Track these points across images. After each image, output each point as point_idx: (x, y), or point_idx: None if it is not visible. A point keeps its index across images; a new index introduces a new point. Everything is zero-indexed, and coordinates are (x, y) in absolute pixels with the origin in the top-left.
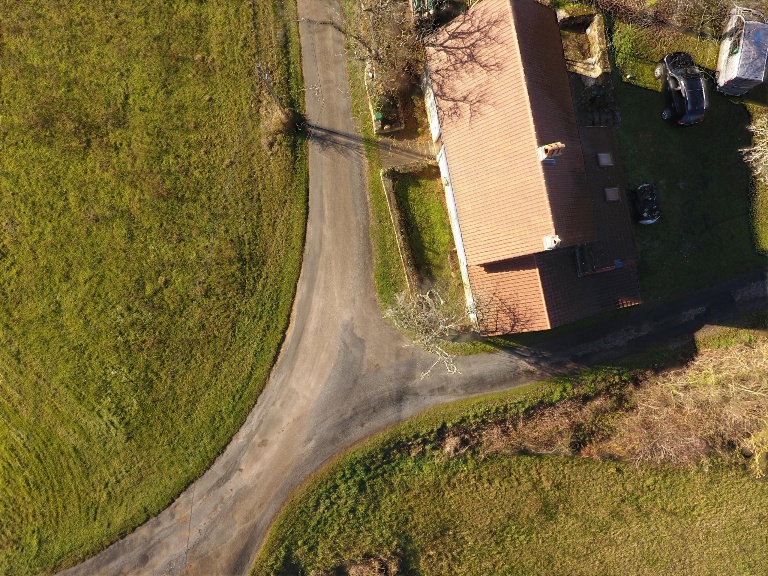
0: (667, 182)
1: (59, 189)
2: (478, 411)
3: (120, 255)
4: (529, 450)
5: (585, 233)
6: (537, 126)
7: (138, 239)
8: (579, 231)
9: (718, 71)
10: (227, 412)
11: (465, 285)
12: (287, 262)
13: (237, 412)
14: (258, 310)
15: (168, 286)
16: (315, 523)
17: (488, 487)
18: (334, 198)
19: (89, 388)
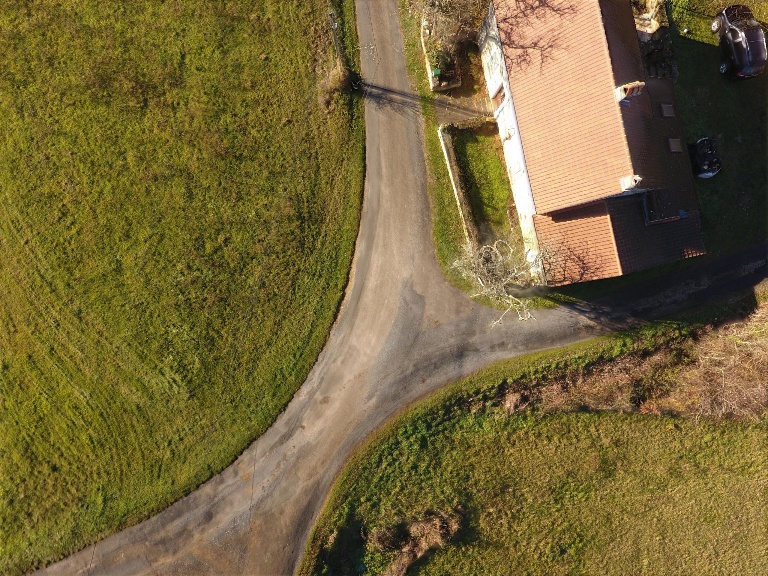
0: (725, 136)
1: (117, 149)
2: (539, 366)
3: (179, 214)
4: (589, 406)
5: (657, 178)
6: (614, 67)
7: (197, 198)
8: (652, 175)
9: None
10: (288, 369)
11: (526, 240)
12: (345, 220)
13: (298, 369)
14: (317, 268)
15: (228, 244)
16: (377, 479)
17: (547, 444)
18: (391, 156)
19: (151, 346)
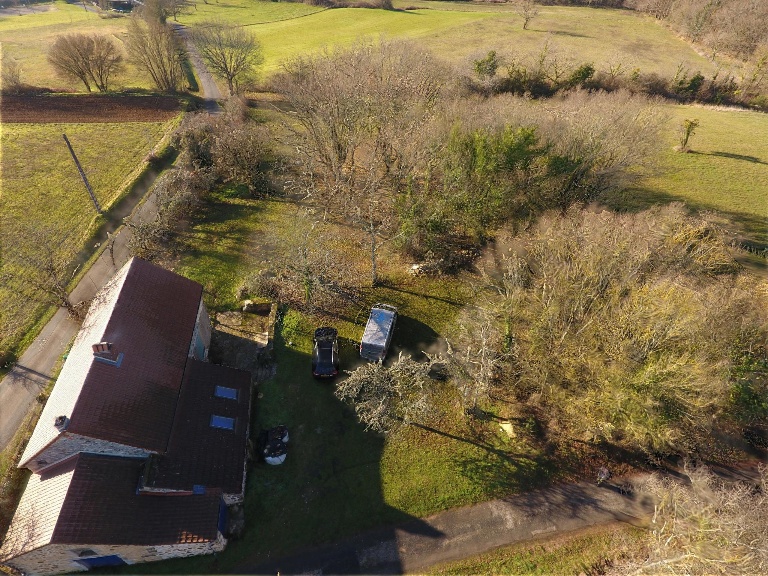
0: (306, 427)
1: None
2: None
3: None
4: None
5: (137, 436)
6: (109, 335)
7: None
8: (125, 430)
9: None
10: None
11: None
12: None
13: None
14: None
15: None
16: None
17: None
18: None
19: None
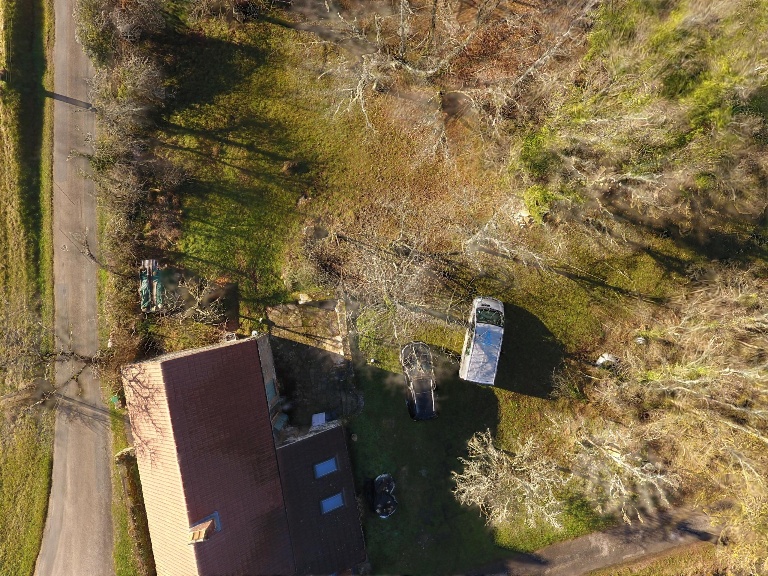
0: (410, 469)
1: None
2: None
3: None
4: None
5: None
6: (192, 502)
7: None
8: None
9: (461, 359)
10: None
11: None
12: (27, 539)
13: None
14: None
15: None
16: None
17: None
18: (77, 473)
19: None
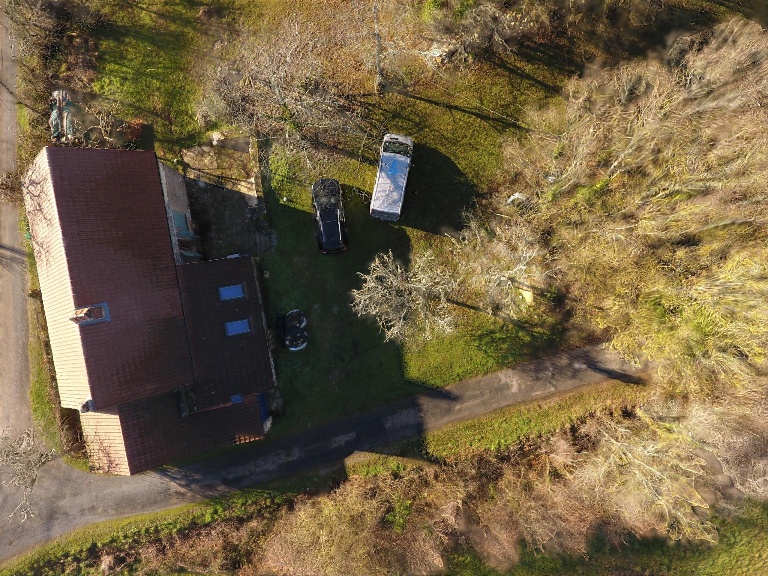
0: (322, 306)
1: None
2: (128, 532)
3: None
4: (186, 569)
5: (163, 382)
6: (78, 287)
7: None
8: (149, 383)
9: None
10: None
11: None
12: None
13: None
14: None
15: None
16: None
17: None
18: None
19: None
